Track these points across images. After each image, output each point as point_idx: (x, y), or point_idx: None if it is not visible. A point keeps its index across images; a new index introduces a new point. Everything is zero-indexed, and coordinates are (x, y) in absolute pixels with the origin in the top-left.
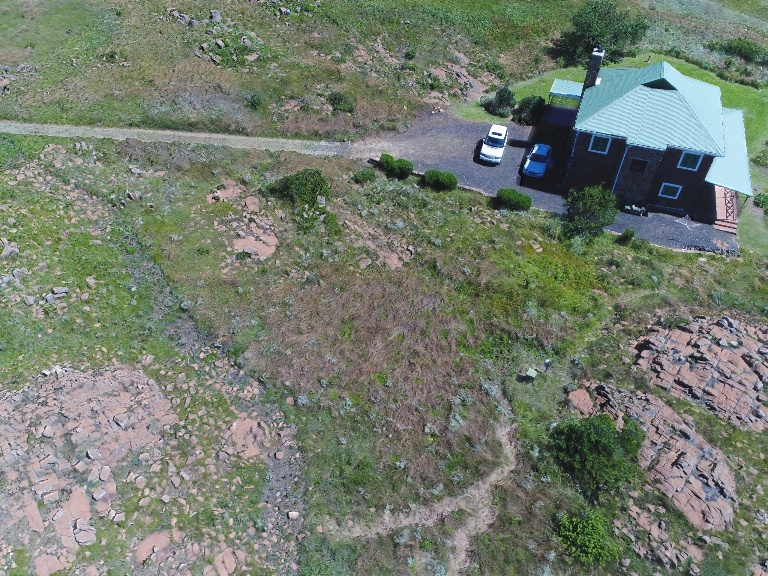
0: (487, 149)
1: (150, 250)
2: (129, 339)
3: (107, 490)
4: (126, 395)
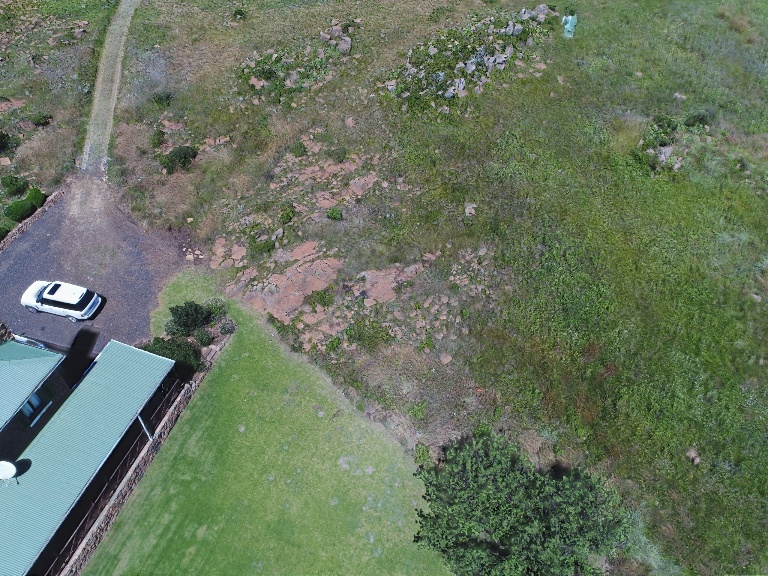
0: (38, 285)
1: None
2: None
3: None
4: None
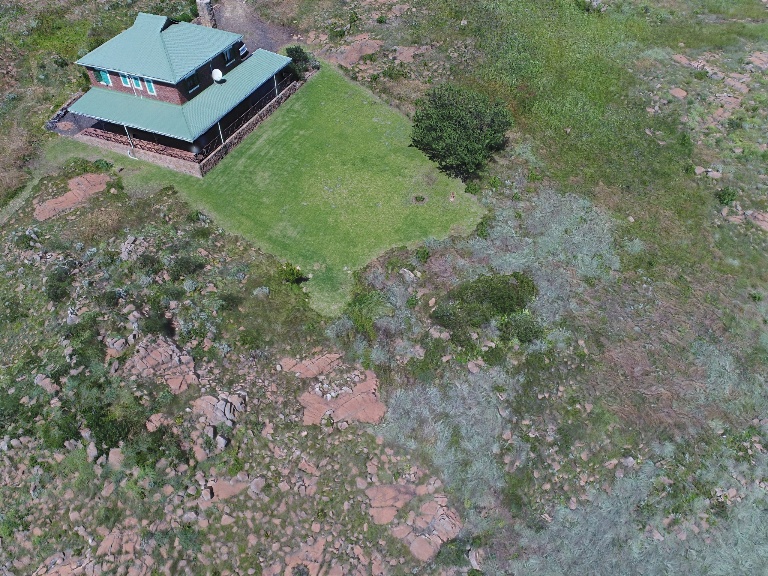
0: None
1: None
2: None
3: None
4: None
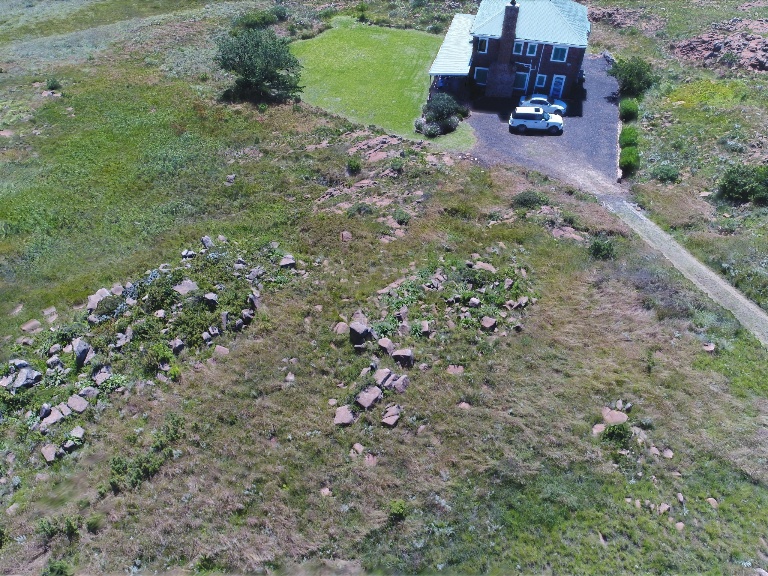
0: (556, 119)
1: None
2: None
3: None
4: None
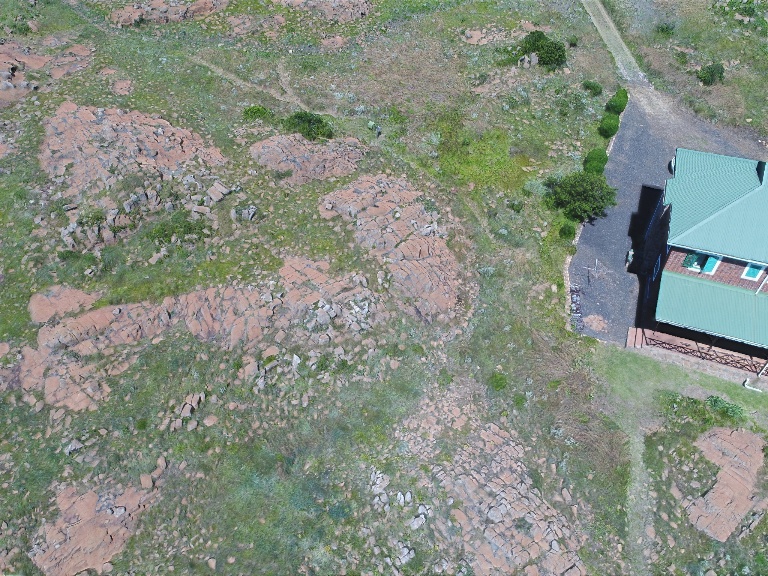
0: None
1: (459, 6)
2: (389, 7)
3: (304, 8)
4: (351, 6)
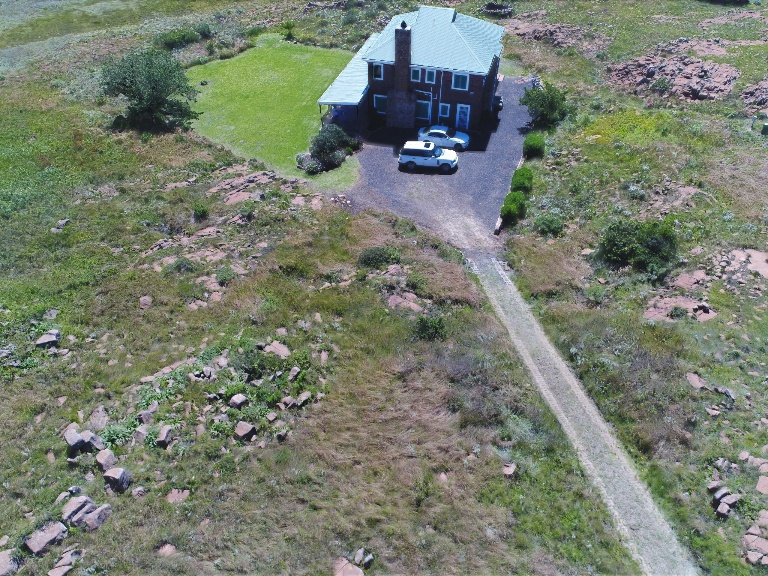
0: (448, 156)
1: None
2: None
3: None
4: None
